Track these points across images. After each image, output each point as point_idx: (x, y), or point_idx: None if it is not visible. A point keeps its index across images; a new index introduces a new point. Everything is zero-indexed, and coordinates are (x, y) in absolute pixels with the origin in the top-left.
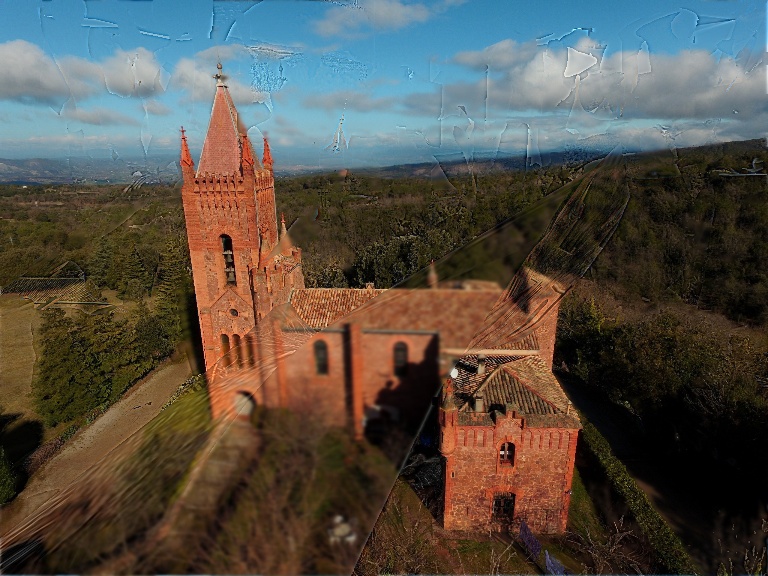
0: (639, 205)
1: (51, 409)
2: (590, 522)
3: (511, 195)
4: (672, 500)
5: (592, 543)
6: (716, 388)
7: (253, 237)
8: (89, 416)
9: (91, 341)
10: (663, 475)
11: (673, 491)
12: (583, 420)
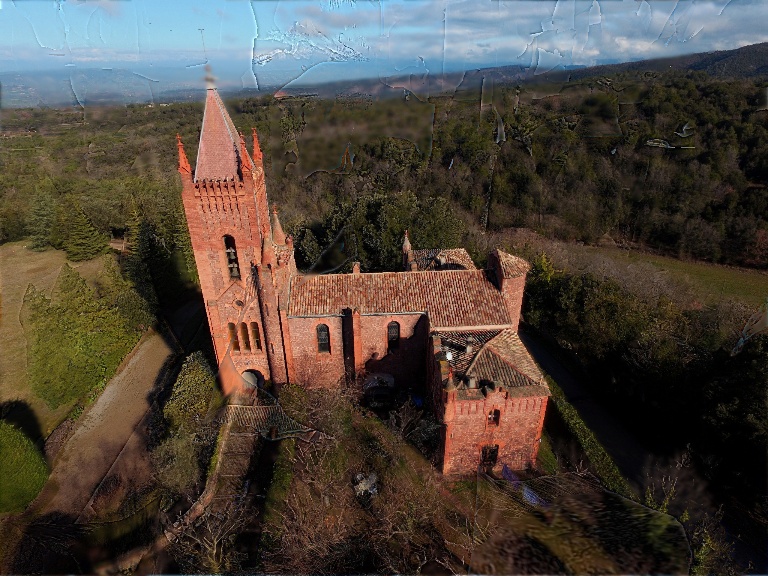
0: (584, 160)
1: (54, 393)
2: (552, 457)
3: (466, 143)
4: (610, 433)
5: None
6: (646, 347)
7: (255, 236)
8: (91, 395)
9: (77, 323)
10: (603, 412)
11: (610, 425)
12: (542, 373)
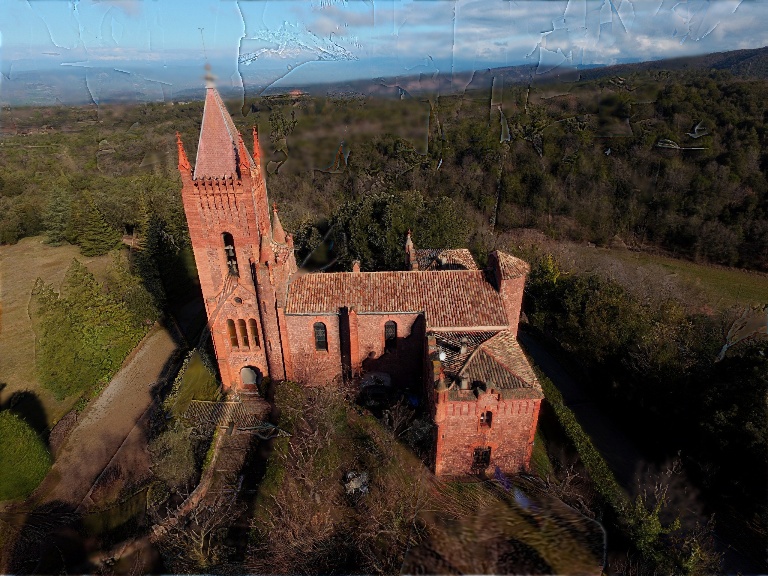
0: (594, 161)
1: (60, 385)
2: (546, 461)
3: (475, 143)
4: (608, 437)
5: (550, 485)
6: (647, 351)
7: (253, 234)
8: (96, 388)
9: (85, 317)
10: (602, 416)
11: (609, 430)
12: (542, 375)
